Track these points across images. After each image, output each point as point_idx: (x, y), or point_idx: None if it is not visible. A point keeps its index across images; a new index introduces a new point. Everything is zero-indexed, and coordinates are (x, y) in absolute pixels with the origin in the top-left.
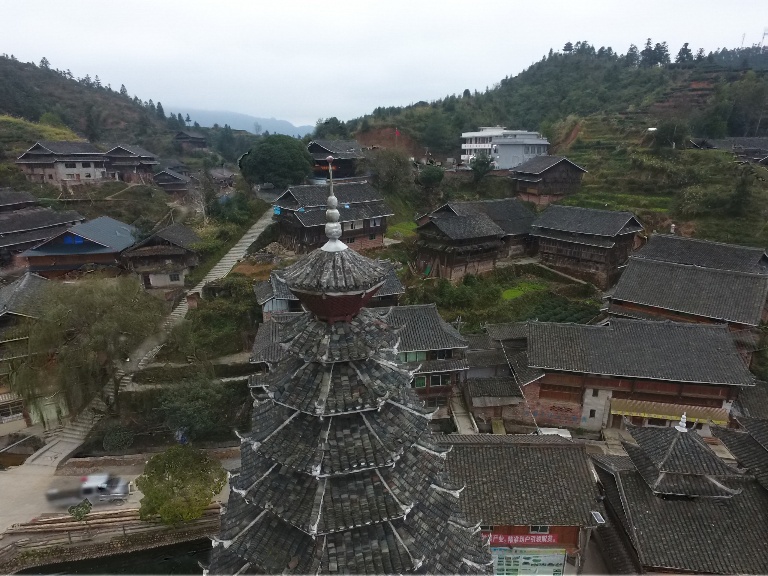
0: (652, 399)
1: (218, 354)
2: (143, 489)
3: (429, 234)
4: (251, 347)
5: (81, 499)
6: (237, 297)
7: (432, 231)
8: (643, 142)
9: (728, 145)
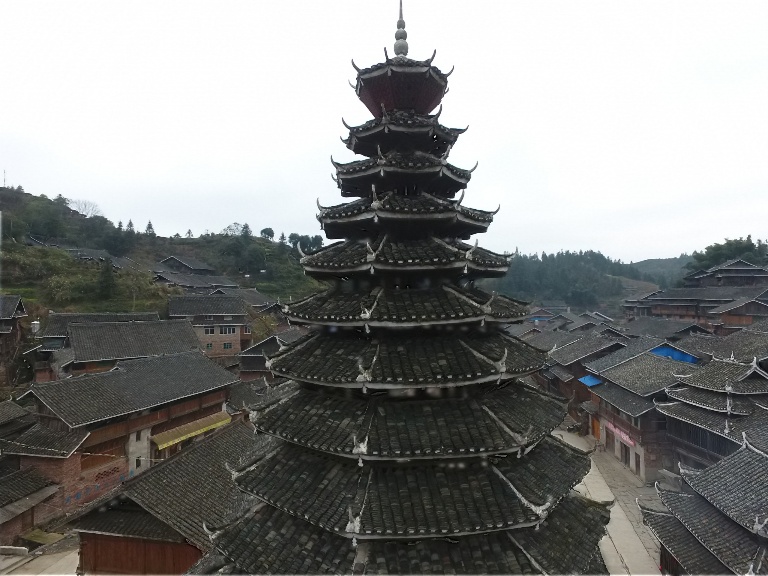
0: (180, 423)
1: None
2: None
3: None
4: None
5: None
6: None
7: None
8: None
9: (71, 243)
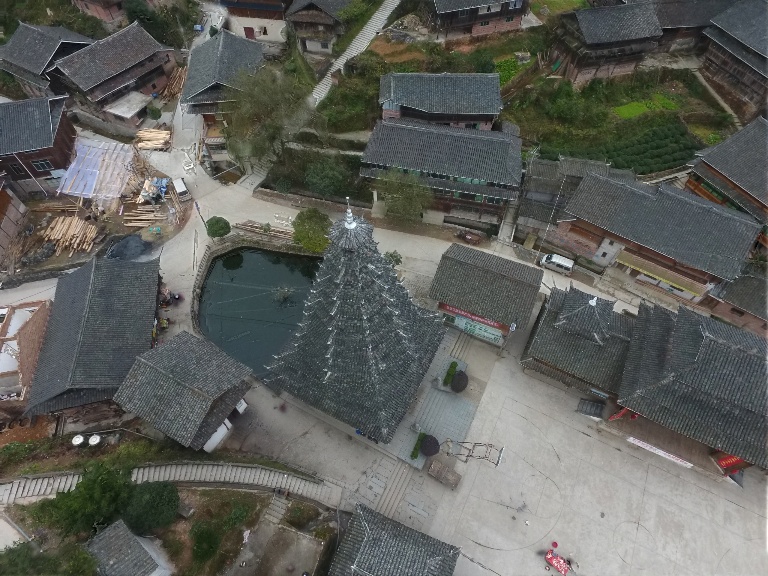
0: (654, 261)
1: (349, 129)
2: (295, 228)
3: (570, 26)
4: (373, 127)
5: (266, 217)
6: (369, 79)
7: (574, 23)
8: None
9: None
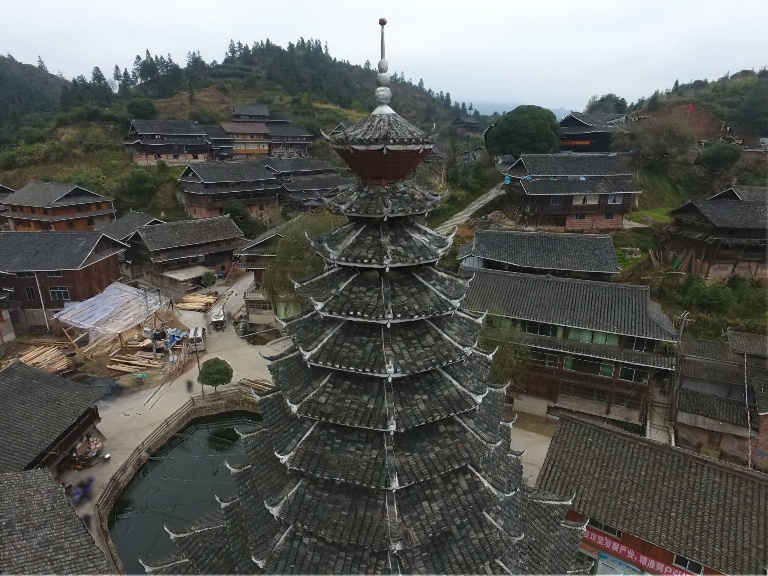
0: None
1: None
2: None
3: (686, 219)
4: None
5: None
6: None
7: (691, 216)
8: None
9: None
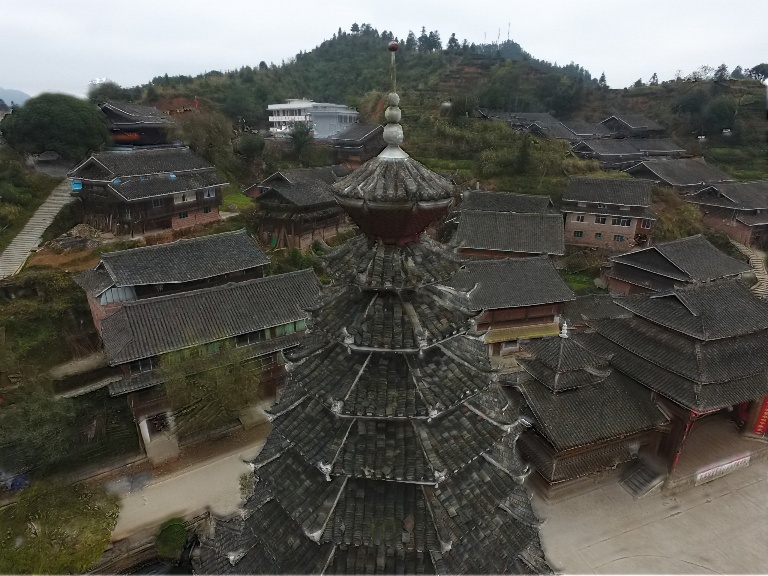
0: (506, 326)
1: None
2: None
3: (271, 203)
4: (84, 353)
5: None
6: (48, 295)
7: (274, 199)
8: (441, 112)
9: (507, 114)
